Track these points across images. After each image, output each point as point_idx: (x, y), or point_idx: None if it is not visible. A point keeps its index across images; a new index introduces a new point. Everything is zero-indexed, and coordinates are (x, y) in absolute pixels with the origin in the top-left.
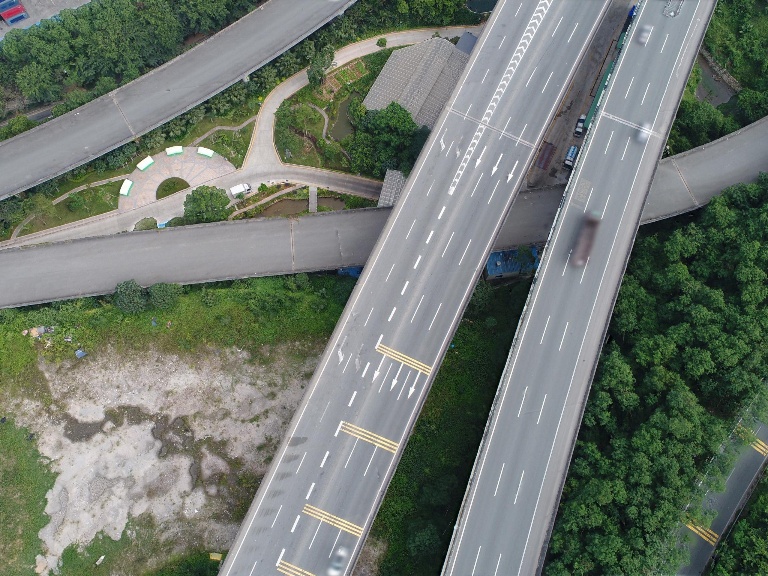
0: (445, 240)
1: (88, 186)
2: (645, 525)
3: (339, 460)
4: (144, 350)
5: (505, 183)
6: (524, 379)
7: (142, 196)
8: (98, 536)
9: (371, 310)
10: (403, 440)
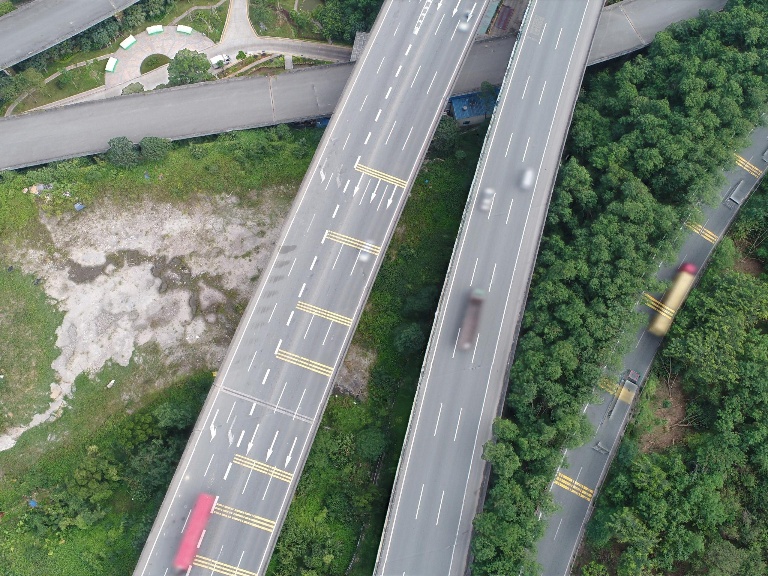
0: (413, 73)
1: (75, 63)
2: (606, 293)
3: (327, 263)
4: (139, 200)
5: (465, 22)
6: (492, 187)
7: (127, 72)
8: (107, 363)
9: (348, 135)
10: (384, 244)
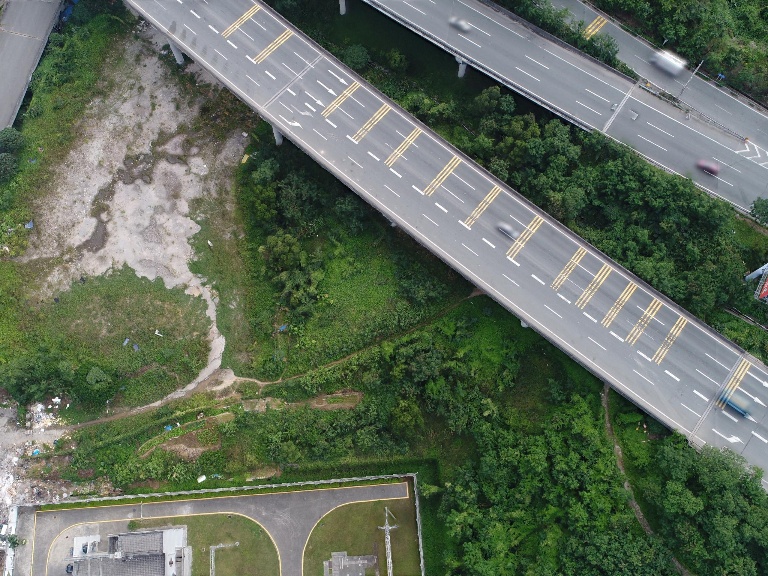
0: None
1: None
2: None
3: (201, 6)
4: (53, 174)
5: None
6: None
7: None
8: (191, 243)
9: None
10: None
